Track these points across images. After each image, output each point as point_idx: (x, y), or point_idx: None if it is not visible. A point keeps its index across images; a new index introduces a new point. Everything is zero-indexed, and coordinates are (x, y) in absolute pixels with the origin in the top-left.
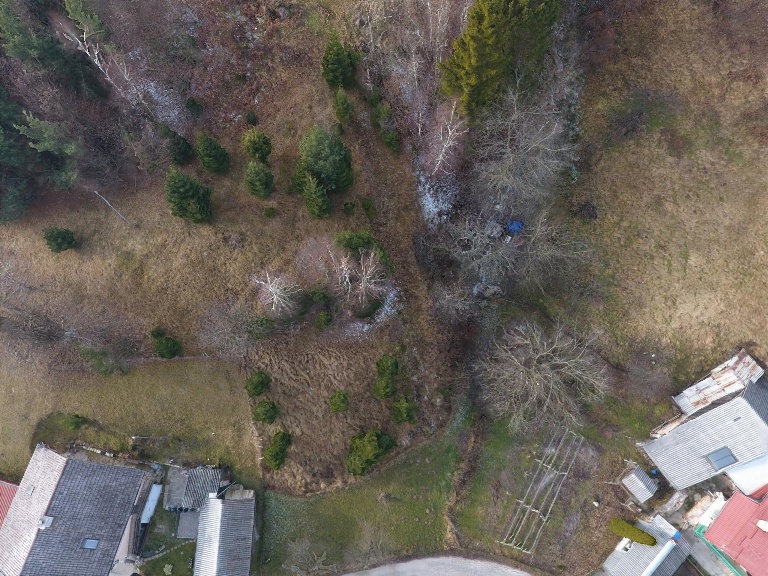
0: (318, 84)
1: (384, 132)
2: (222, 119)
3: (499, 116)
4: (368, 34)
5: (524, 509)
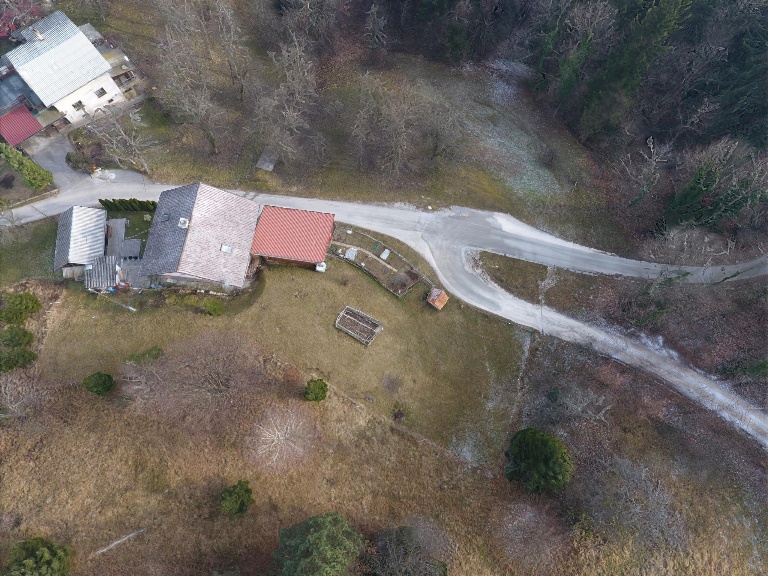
0: None
1: None
2: None
3: None
4: None
5: None
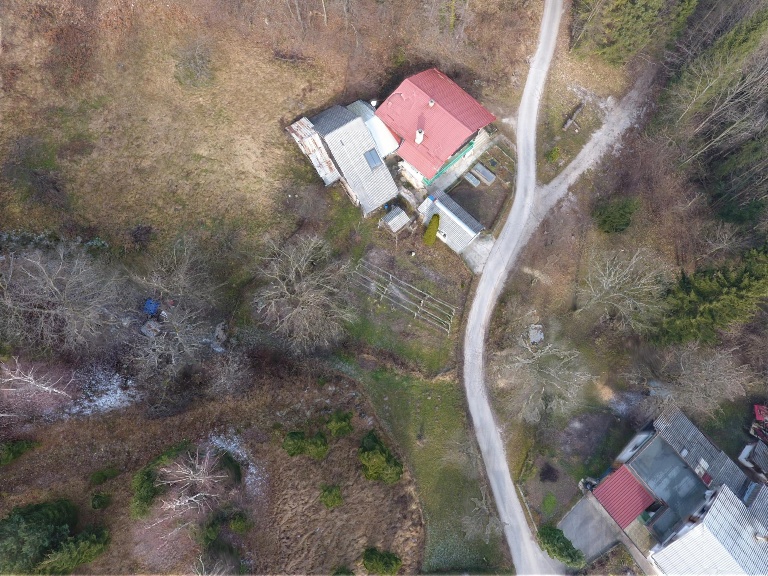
0: None
1: None
2: None
3: (4, 320)
4: None
5: (421, 312)
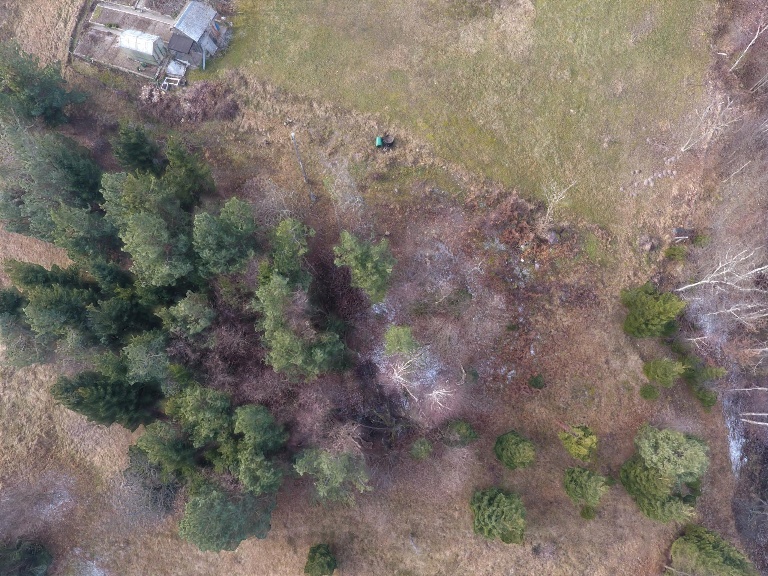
0: (609, 329)
1: (701, 388)
2: (492, 377)
3: None
4: (659, 260)
5: None
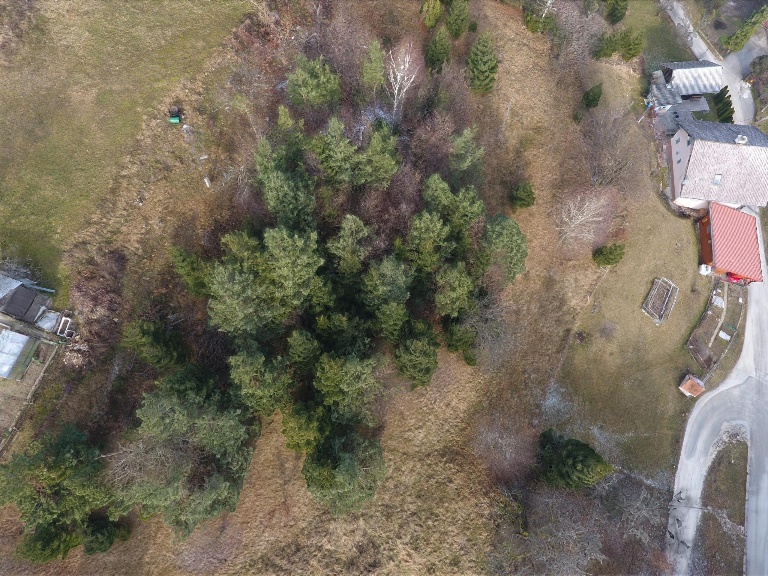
0: None
1: None
2: None
3: None
4: None
5: None
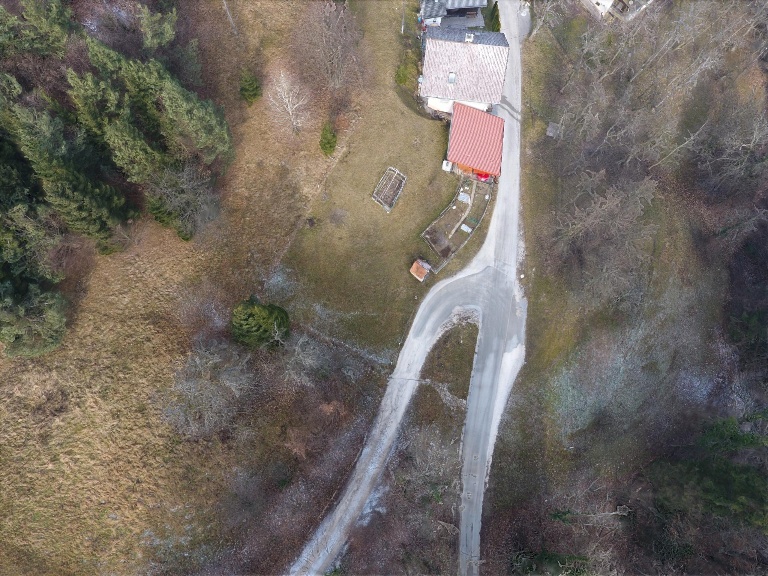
0: None
1: None
2: None
3: None
4: None
5: None
